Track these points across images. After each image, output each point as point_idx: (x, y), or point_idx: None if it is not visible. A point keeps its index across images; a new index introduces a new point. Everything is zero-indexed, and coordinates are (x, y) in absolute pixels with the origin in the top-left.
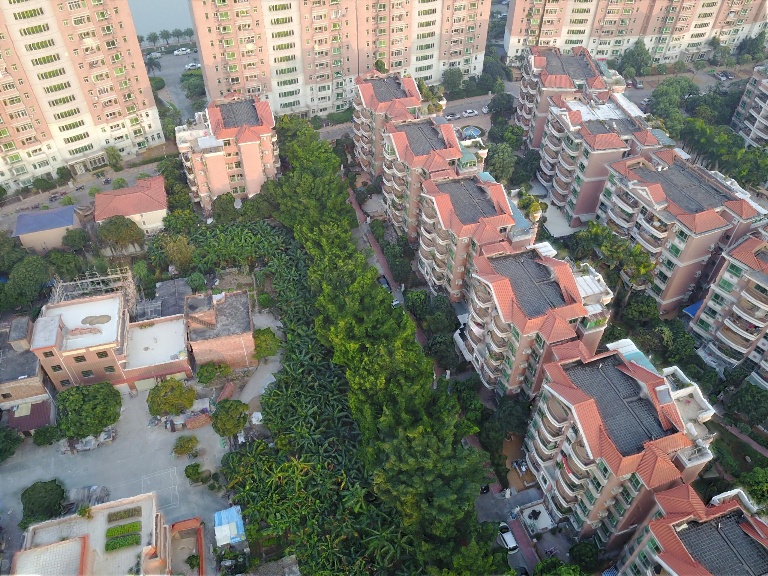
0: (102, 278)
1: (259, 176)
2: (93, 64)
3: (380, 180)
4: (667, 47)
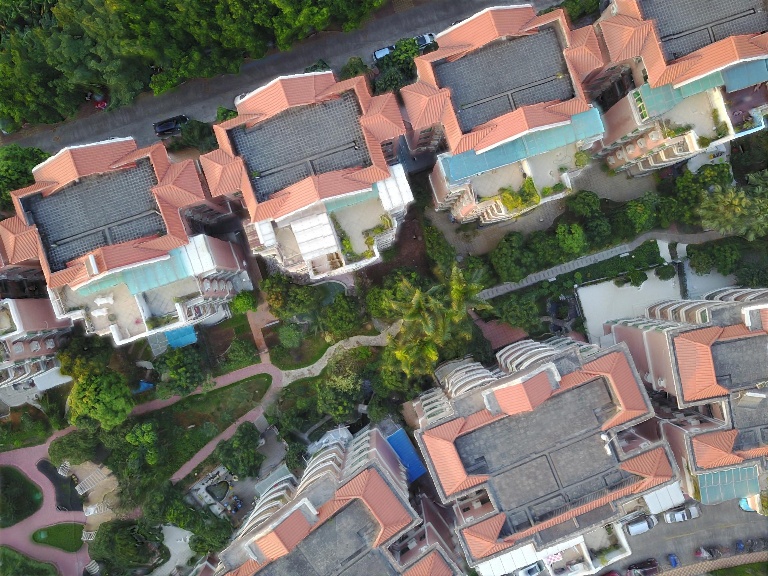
0: None
1: None
2: None
3: None
4: None
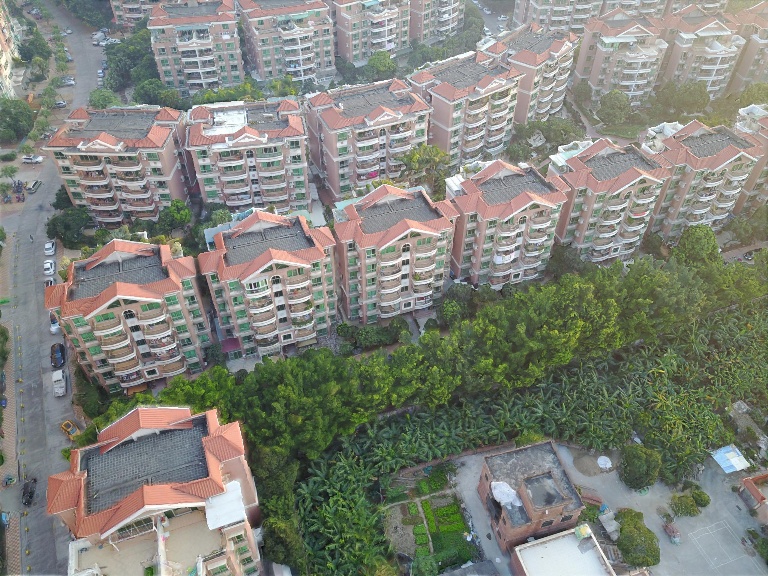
0: None
1: None
2: None
3: (220, 350)
4: (7, 90)
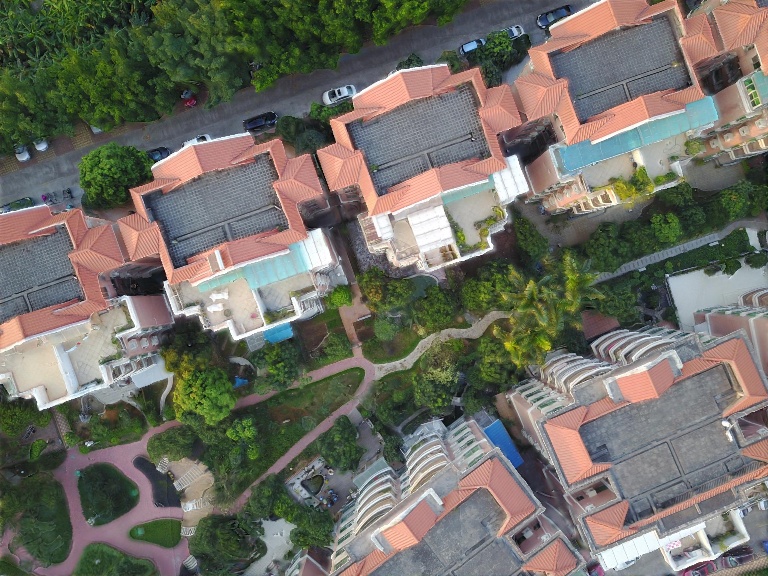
0: None
1: None
2: None
3: None
4: None
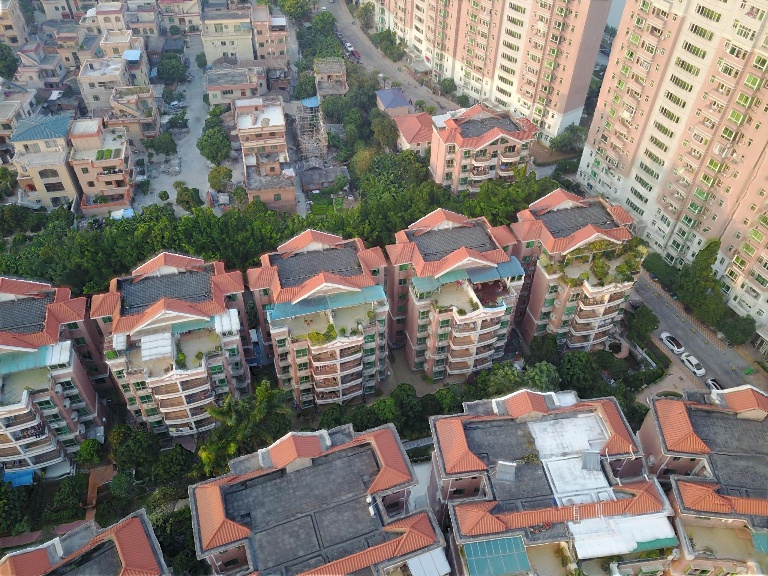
0: None
1: None
2: (537, 45)
3: None
4: None
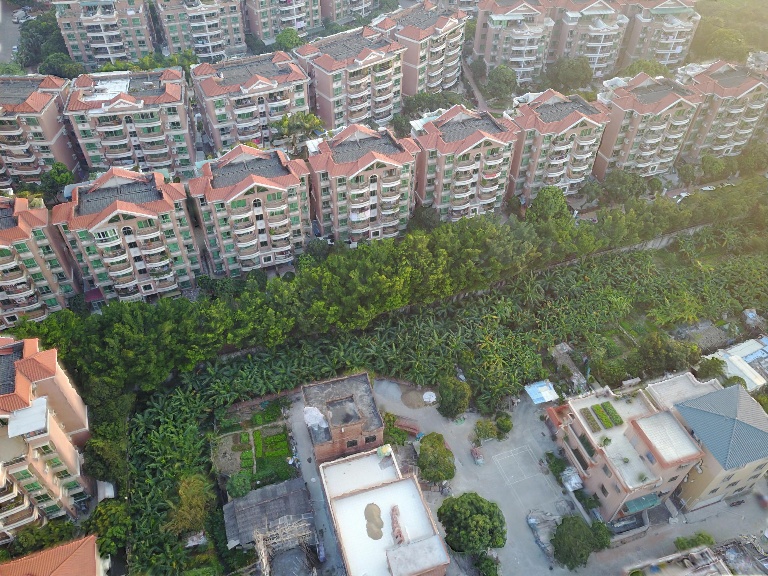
0: (265, 575)
1: (74, 396)
2: None
3: (82, 299)
4: None
